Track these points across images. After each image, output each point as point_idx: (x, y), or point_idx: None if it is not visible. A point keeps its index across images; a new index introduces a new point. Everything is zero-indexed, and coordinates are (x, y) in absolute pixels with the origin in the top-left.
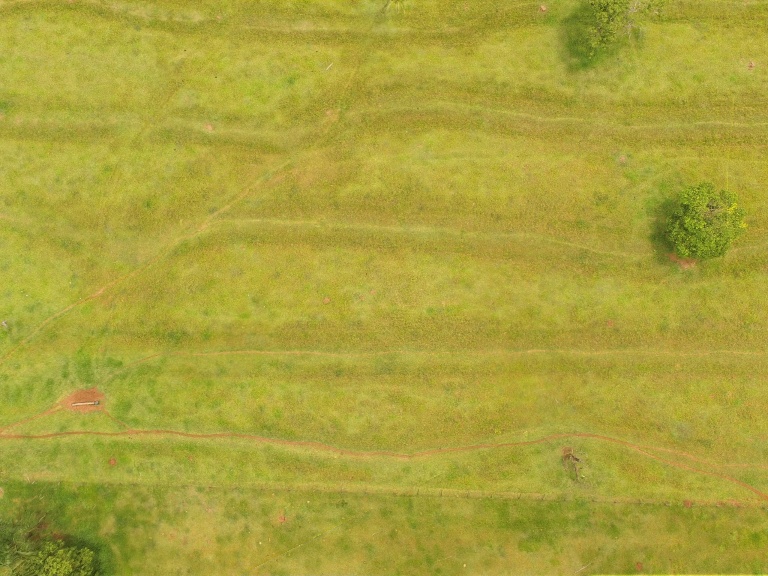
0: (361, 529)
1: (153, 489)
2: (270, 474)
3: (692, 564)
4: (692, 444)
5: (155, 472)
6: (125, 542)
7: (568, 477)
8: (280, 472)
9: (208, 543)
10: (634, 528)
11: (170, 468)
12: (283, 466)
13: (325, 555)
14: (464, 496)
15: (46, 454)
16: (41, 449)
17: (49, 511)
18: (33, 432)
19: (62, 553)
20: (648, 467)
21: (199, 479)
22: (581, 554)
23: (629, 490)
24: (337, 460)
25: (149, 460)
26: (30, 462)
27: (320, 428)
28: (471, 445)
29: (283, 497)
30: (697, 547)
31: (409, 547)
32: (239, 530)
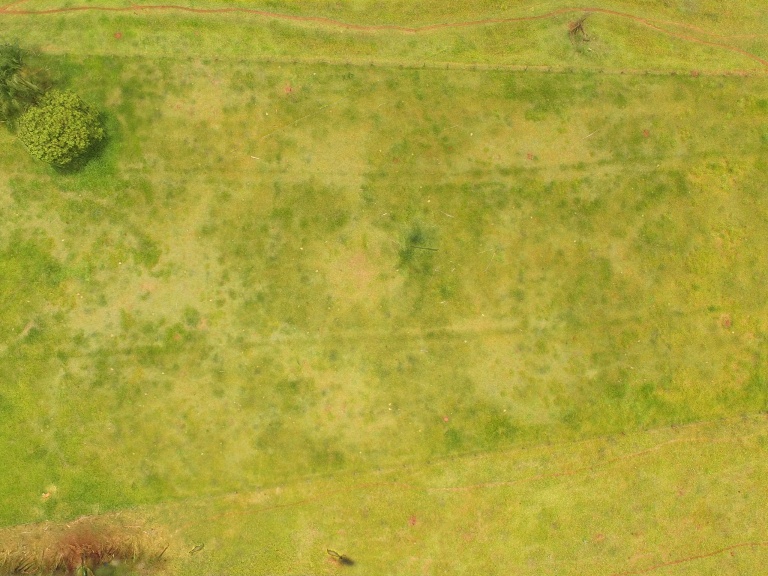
0: (368, 101)
1: (159, 61)
2: (276, 48)
3: (699, 130)
4: (699, 17)
5: (161, 45)
6: (132, 112)
7: (575, 51)
8: (286, 46)
9: (215, 114)
10: (641, 97)
11: (176, 42)
12: (289, 41)
13: (332, 125)
14: (471, 68)
15: (51, 29)
16: (46, 24)
17: (55, 81)
18: (38, 8)
19: (69, 92)
20: (655, 40)
21: (205, 53)
22: (588, 122)
23: (636, 61)
24: (343, 35)
25: (155, 34)
26: (36, 37)
27: (326, 5)
28: (477, 20)
29: (289, 70)
30: (704, 114)
31: (416, 117)
32: (245, 102)
